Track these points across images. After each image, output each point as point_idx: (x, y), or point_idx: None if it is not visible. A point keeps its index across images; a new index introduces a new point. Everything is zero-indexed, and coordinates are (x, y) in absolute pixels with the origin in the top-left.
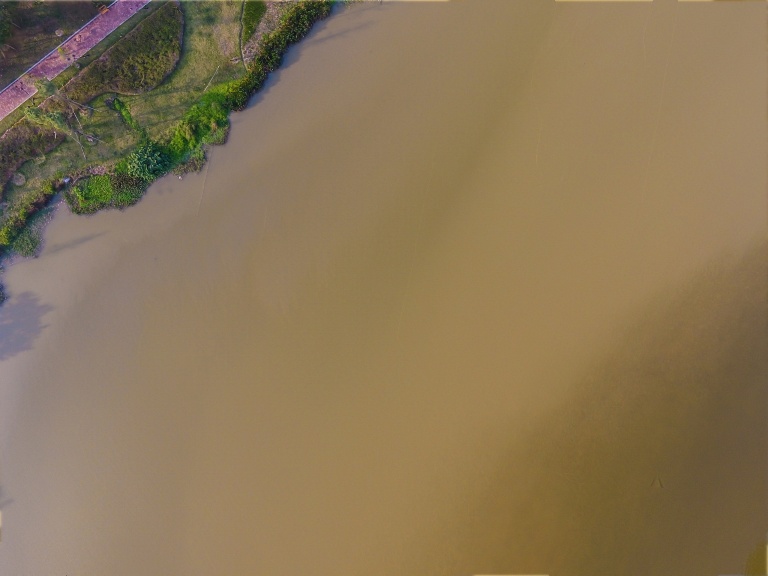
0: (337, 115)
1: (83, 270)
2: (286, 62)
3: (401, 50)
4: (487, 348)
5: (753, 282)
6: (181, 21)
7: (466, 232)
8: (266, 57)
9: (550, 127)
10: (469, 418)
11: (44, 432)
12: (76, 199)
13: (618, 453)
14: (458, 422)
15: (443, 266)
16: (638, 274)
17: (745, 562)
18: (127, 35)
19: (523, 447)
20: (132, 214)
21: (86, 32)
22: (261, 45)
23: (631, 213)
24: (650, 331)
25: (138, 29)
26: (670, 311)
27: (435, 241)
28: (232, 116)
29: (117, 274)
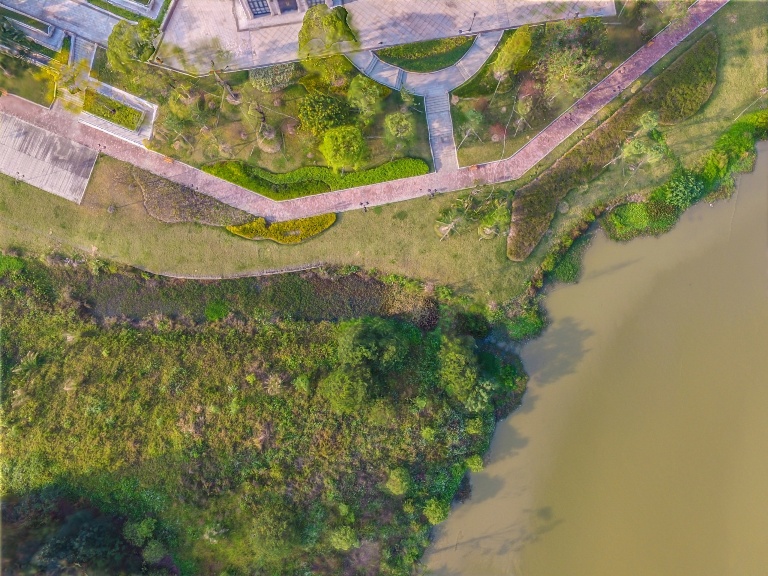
0: None
1: (621, 295)
2: None
3: None
4: None
5: None
6: (717, 53)
7: None
8: None
9: None
10: None
11: (591, 453)
12: (613, 226)
13: None
14: None
15: None
16: None
17: None
18: (671, 67)
19: None
20: (666, 241)
21: (630, 64)
22: None
23: None
24: None
25: (681, 61)
26: None
27: None
28: (759, 145)
29: (655, 299)
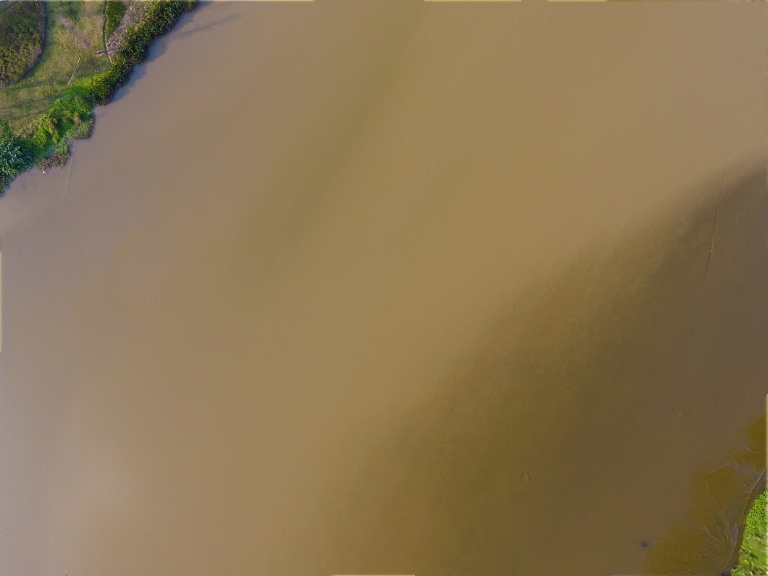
0: (203, 108)
1: None
2: (152, 55)
3: (269, 43)
4: (354, 342)
5: (623, 275)
6: (42, 14)
7: (334, 226)
8: (129, 50)
9: (419, 120)
10: (336, 413)
11: None
12: None
13: (486, 447)
14: (325, 417)
15: (310, 260)
16: (507, 267)
17: (644, 556)
18: None
19: (390, 441)
20: None
21: None
22: (126, 38)
23: (500, 206)
24: (519, 324)
25: None
26: (540, 304)
27: (302, 235)
28: (97, 110)
29: None
